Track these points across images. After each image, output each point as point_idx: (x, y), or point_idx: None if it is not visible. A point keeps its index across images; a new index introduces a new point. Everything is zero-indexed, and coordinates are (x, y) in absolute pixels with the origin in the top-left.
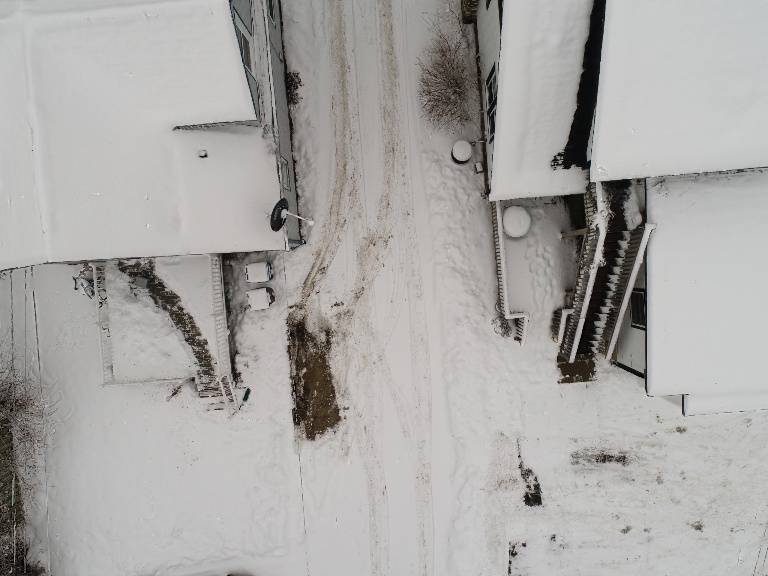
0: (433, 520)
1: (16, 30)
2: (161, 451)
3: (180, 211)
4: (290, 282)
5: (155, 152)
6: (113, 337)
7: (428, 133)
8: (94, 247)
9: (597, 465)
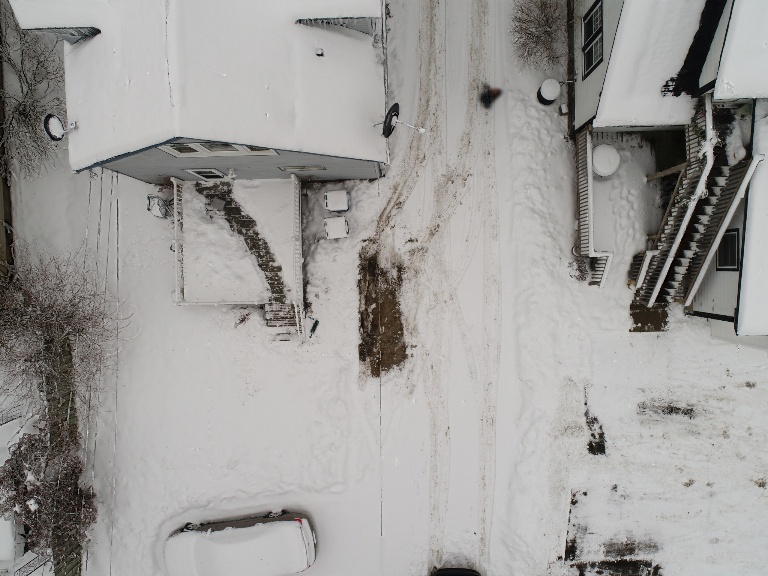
0: (495, 463)
1: None
2: (223, 380)
3: (296, 106)
4: (365, 215)
5: (277, 43)
6: (187, 257)
7: (515, 72)
8: (218, 128)
9: (663, 416)
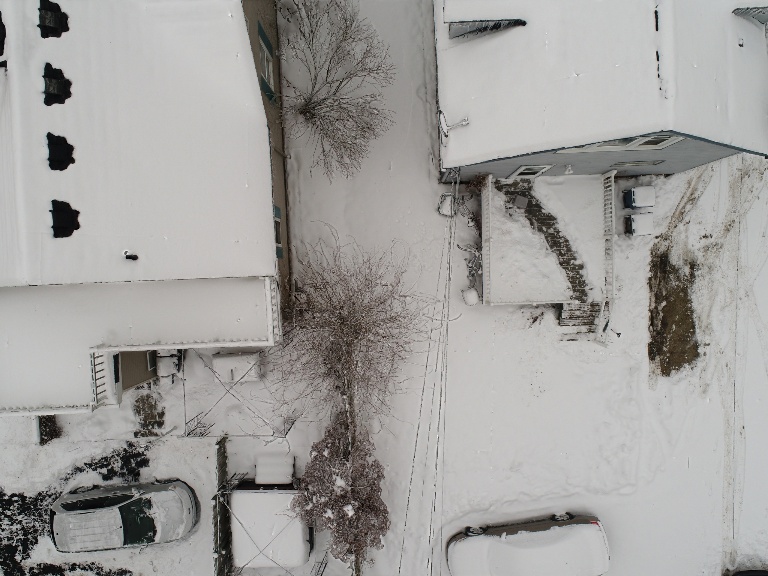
0: None
1: None
2: (506, 381)
3: (728, 98)
4: (659, 211)
5: (720, 33)
6: None
7: None
8: (694, 121)
9: None
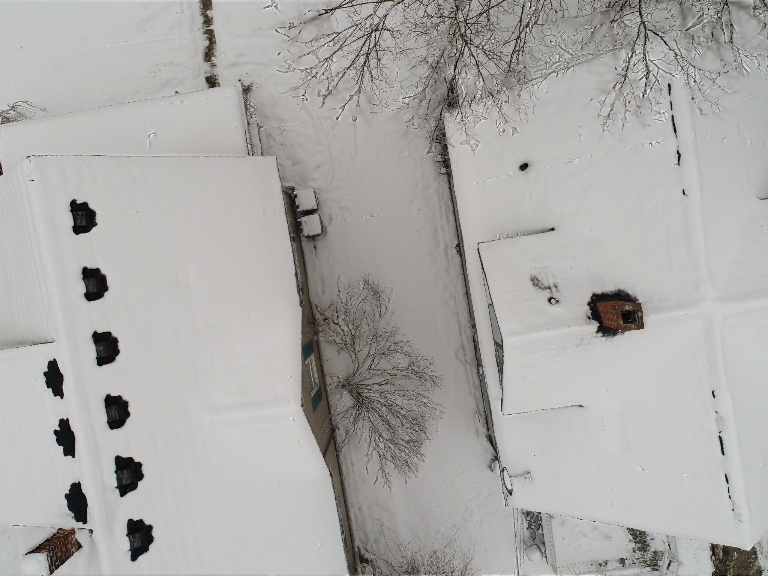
0: None
1: (700, 318)
2: None
3: None
4: None
5: None
6: None
7: None
8: (766, 523)
9: None
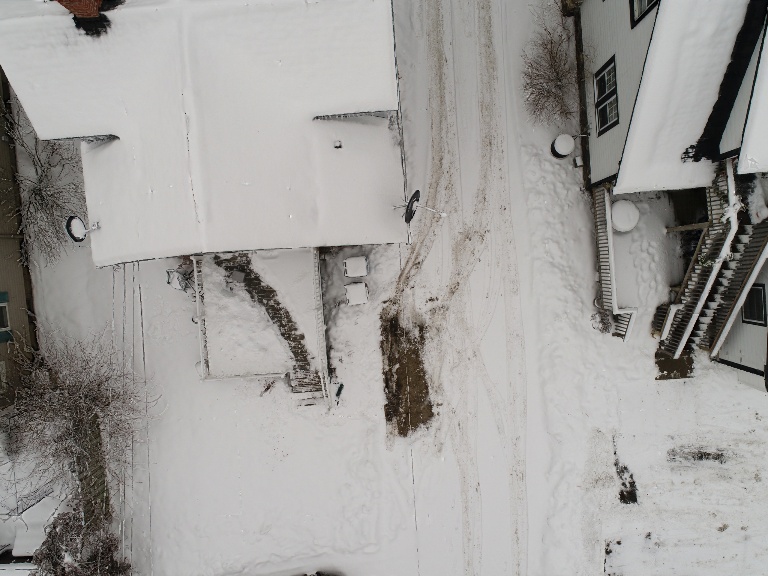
0: (527, 517)
1: (173, 17)
2: (251, 447)
3: (318, 202)
4: (385, 277)
5: (296, 142)
6: (210, 331)
7: (527, 127)
8: (244, 237)
9: (694, 462)
